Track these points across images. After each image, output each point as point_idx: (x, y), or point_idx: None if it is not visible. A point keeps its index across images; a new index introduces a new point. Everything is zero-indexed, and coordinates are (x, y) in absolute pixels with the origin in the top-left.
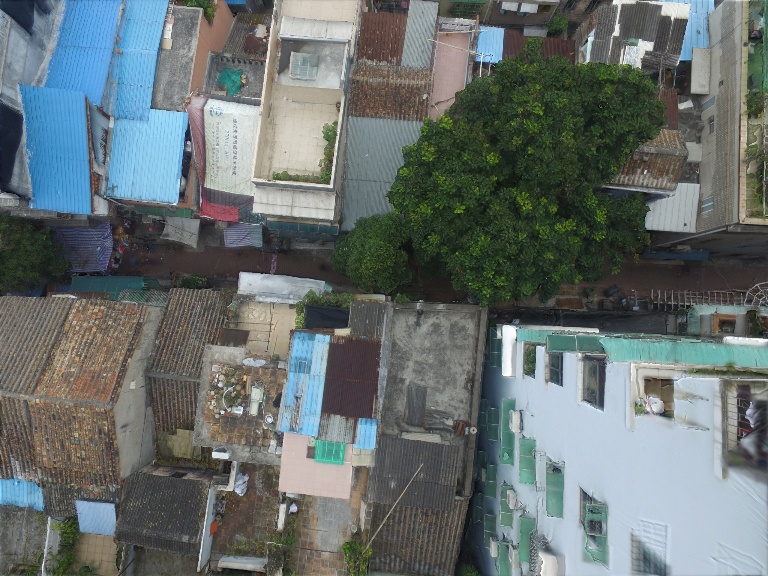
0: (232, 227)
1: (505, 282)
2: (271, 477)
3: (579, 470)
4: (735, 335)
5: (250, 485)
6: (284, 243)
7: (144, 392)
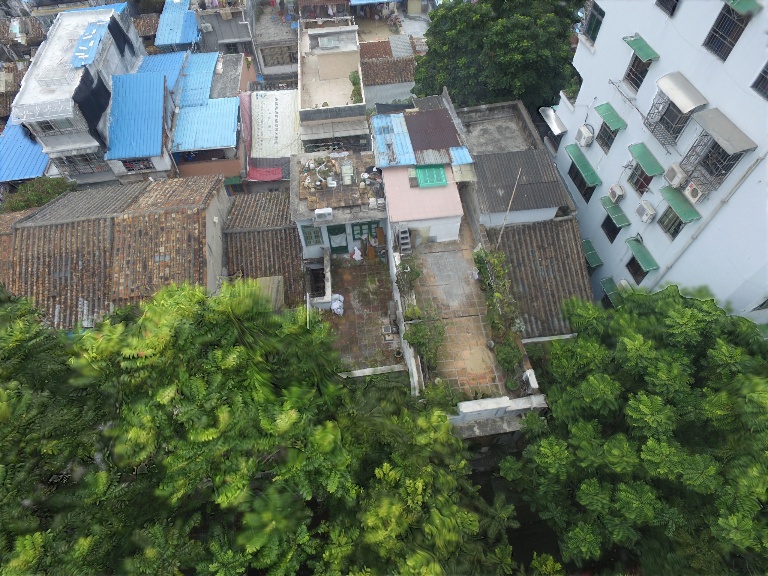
0: None
1: (528, 43)
2: (367, 295)
3: (647, 0)
4: None
5: (346, 307)
6: None
7: (221, 247)
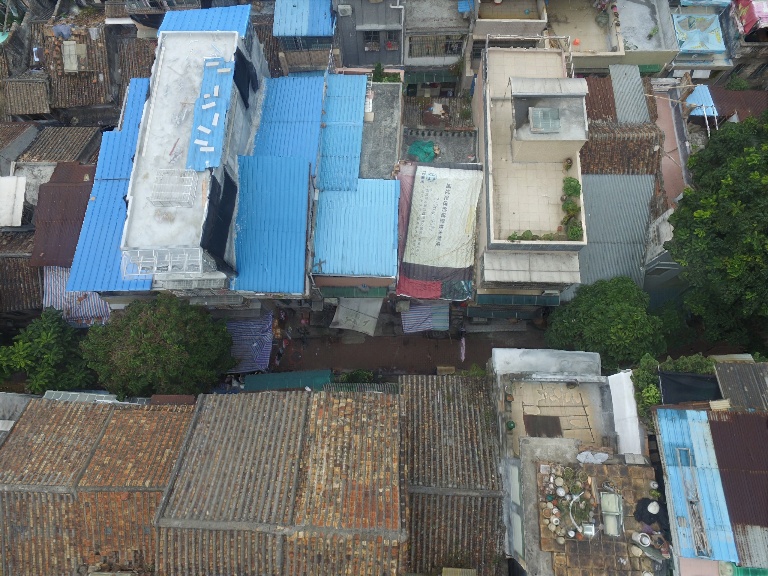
0: (411, 310)
1: None
2: None
3: None
4: None
5: None
6: (463, 326)
7: None
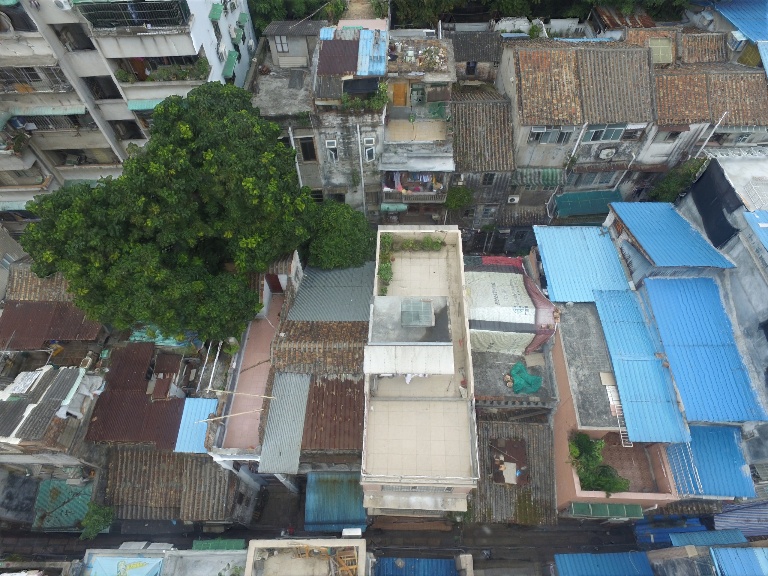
0: None
1: None
2: None
3: None
4: (36, 157)
5: None
6: None
7: None
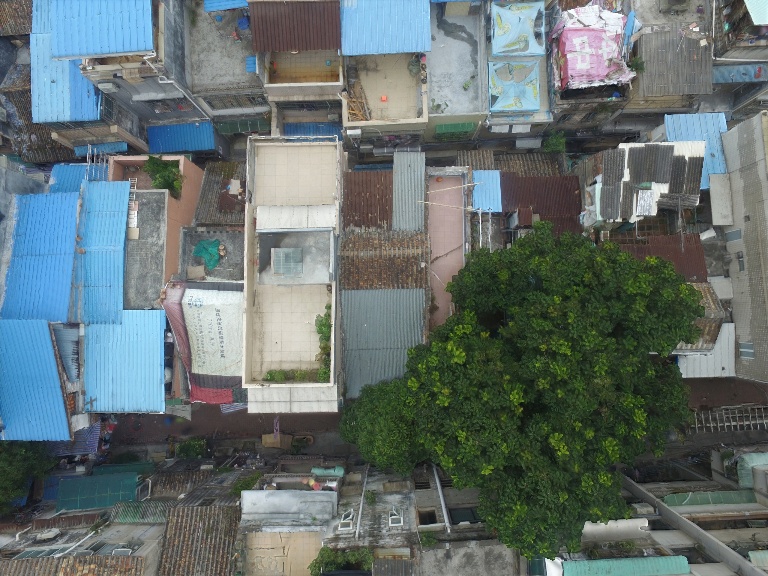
0: None
1: (549, 548)
2: None
3: None
4: None
5: None
6: None
7: None
